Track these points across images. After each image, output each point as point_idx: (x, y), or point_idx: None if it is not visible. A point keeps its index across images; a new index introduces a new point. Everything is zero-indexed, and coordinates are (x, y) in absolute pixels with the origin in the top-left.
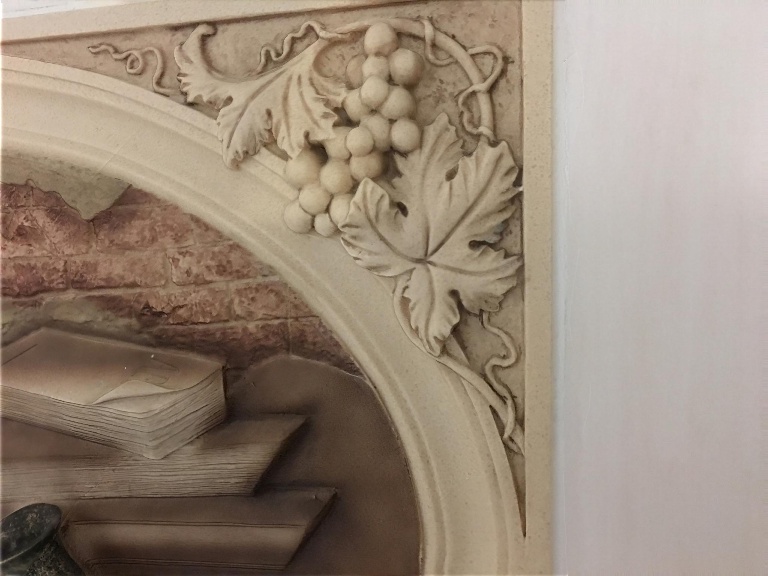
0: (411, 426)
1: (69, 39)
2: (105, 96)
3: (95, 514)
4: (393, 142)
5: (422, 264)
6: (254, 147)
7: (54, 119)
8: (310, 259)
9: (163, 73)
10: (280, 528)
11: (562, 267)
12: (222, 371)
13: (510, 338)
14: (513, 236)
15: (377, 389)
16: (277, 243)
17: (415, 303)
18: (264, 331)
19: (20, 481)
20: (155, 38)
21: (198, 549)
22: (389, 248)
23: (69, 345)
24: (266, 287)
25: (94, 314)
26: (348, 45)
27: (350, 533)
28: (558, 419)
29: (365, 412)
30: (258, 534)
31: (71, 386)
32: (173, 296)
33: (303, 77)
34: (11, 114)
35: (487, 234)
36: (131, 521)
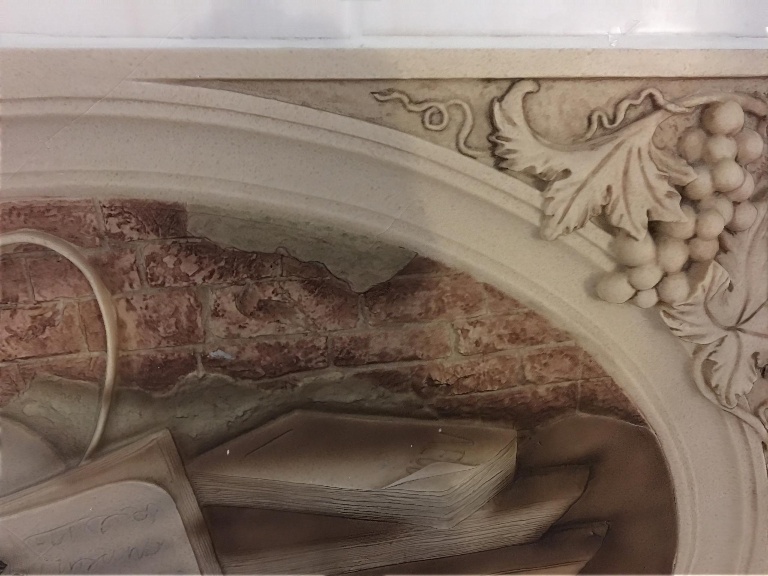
0: (683, 462)
1: (347, 81)
2: (399, 156)
3: None
4: (734, 224)
5: (732, 331)
6: (582, 221)
7: (312, 174)
8: (608, 324)
9: (471, 131)
10: (564, 566)
11: None
12: (516, 437)
13: None
14: None
15: (658, 435)
16: (578, 310)
17: (721, 366)
18: (554, 393)
19: (269, 568)
20: (461, 88)
21: None
22: (710, 320)
23: (336, 427)
24: (561, 352)
25: (367, 393)
26: (683, 116)
27: (615, 555)
28: None
29: (644, 456)
30: (540, 574)
31: (348, 471)
32: (459, 367)
33: (643, 150)
34: (250, 166)
35: None
36: None
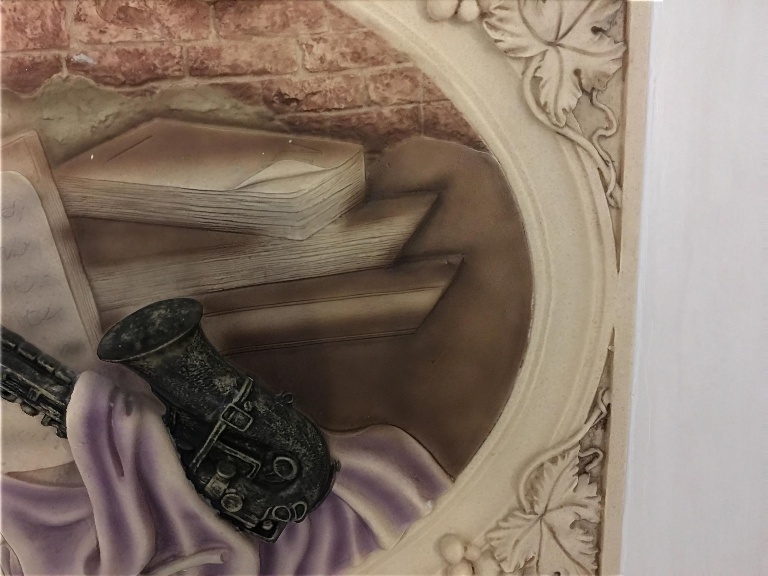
0: (528, 193)
1: None
2: None
3: (229, 303)
4: None
5: (553, 47)
6: None
7: None
8: (443, 47)
9: None
10: (420, 291)
11: (654, 52)
12: (363, 152)
13: (612, 112)
14: (618, 26)
15: (501, 163)
16: (413, 31)
17: (546, 81)
18: (398, 115)
19: (134, 282)
20: None
21: (336, 324)
22: (529, 31)
23: (193, 134)
24: (401, 73)
25: (220, 102)
26: None
27: (473, 292)
28: (645, 176)
29: (490, 184)
30: (398, 300)
31: (204, 174)
32: (306, 83)
33: None
34: None
35: (604, 22)
36: (270, 305)
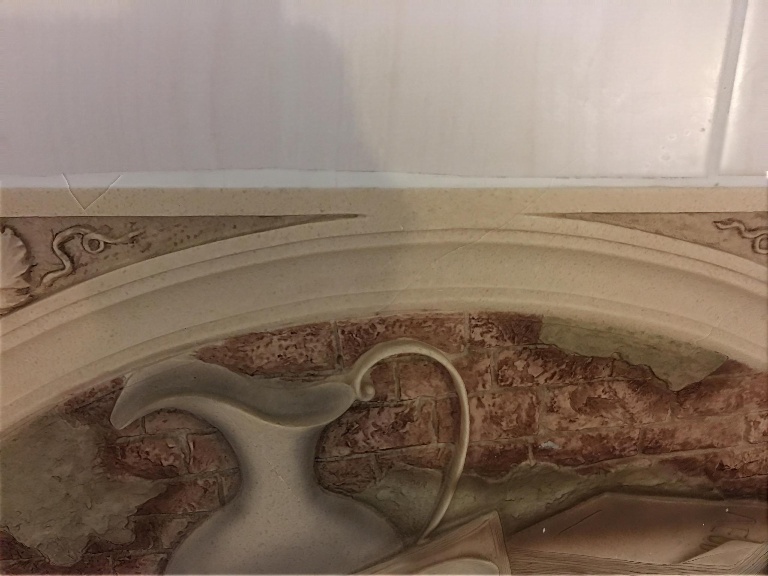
0: None
1: (697, 212)
2: (732, 276)
3: None
4: None
5: None
6: None
7: (650, 289)
8: None
9: None
10: None
11: None
12: None
13: None
14: None
15: None
16: None
17: None
18: None
19: None
20: None
21: None
22: None
23: (640, 508)
24: None
25: (669, 477)
26: None
27: None
28: None
29: None
30: None
31: (650, 548)
32: (746, 454)
33: None
34: (599, 283)
35: None
36: None
